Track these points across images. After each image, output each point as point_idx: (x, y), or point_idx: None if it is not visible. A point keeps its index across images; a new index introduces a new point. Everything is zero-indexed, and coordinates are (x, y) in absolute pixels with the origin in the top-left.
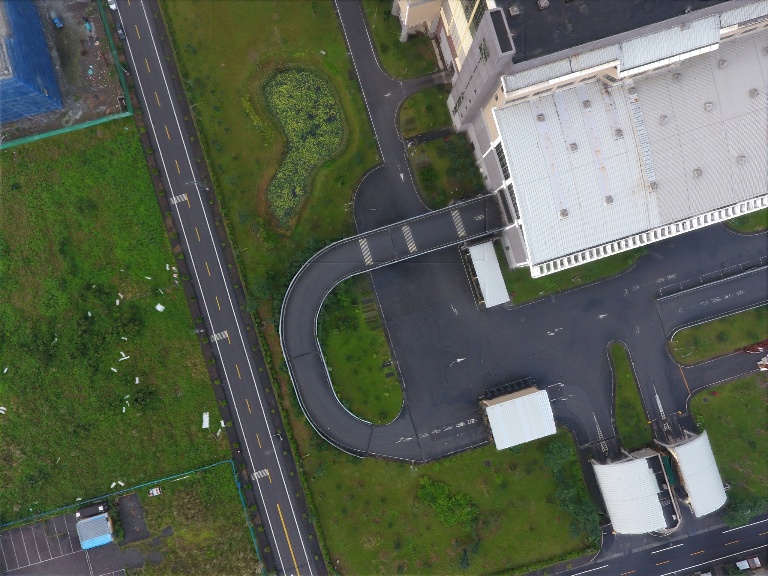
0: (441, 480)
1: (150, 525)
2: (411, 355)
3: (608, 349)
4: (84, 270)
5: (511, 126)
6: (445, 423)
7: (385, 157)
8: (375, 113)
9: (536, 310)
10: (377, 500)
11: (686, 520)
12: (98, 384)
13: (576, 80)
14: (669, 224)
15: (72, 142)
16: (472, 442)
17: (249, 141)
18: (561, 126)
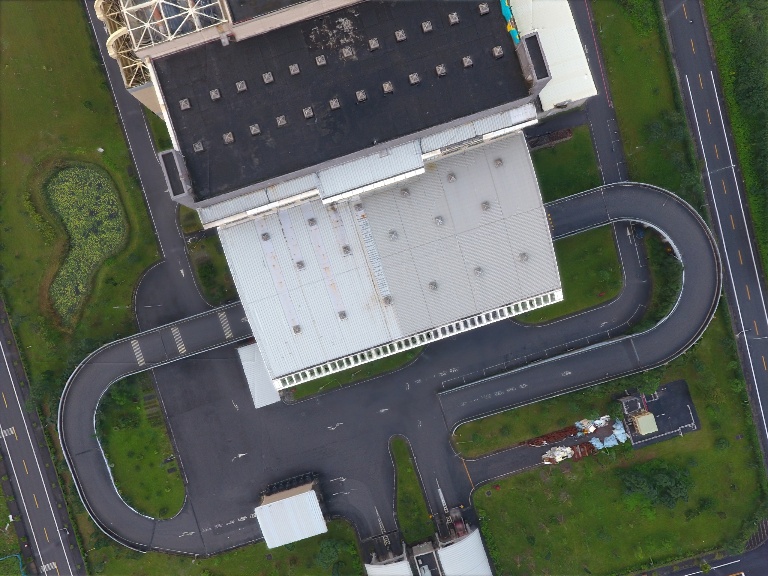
0: (223, 574)
1: None
2: (193, 450)
3: (389, 443)
4: None
5: (236, 245)
6: (227, 517)
7: (166, 253)
8: (155, 209)
9: (317, 405)
10: None
11: None
12: None
13: (294, 201)
14: (411, 335)
15: None
16: (254, 536)
17: (31, 240)
18: (287, 244)
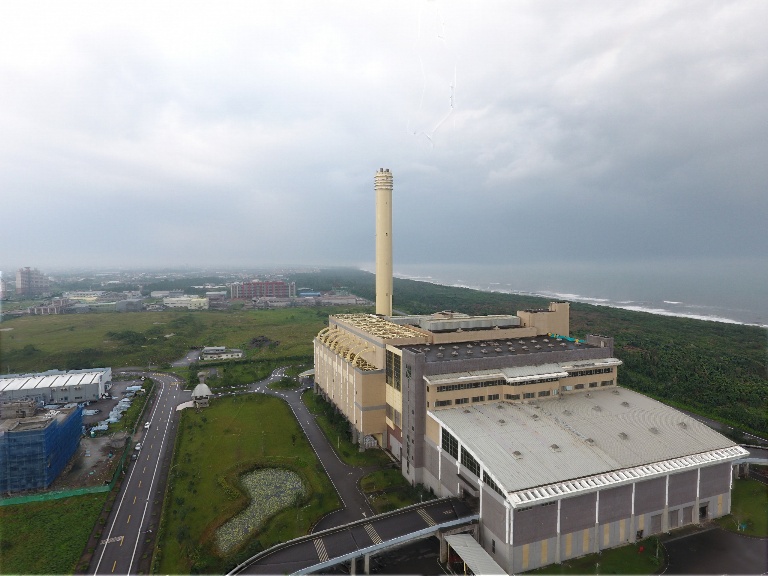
0: None
1: None
2: None
3: None
4: None
5: (445, 416)
6: None
7: (347, 504)
8: (338, 482)
9: None
10: None
11: None
12: None
13: (484, 395)
14: None
15: (34, 507)
16: None
17: (213, 499)
18: (486, 416)
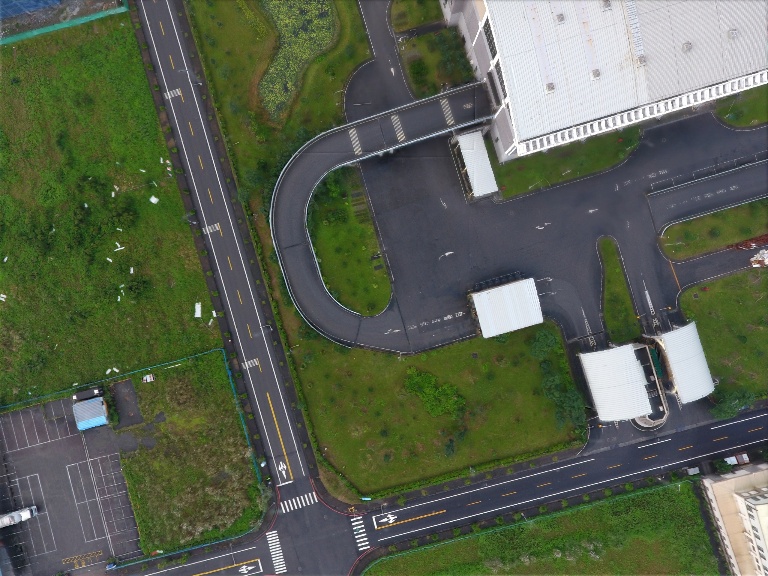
0: (428, 371)
1: (144, 410)
2: (400, 248)
3: (598, 244)
4: (81, 162)
5: None
6: (433, 316)
7: (376, 52)
8: (366, 8)
9: (525, 204)
10: (365, 390)
11: (674, 415)
12: (94, 273)
13: None
14: (658, 102)
15: (69, 38)
16: (460, 335)
17: (242, 36)
18: None
